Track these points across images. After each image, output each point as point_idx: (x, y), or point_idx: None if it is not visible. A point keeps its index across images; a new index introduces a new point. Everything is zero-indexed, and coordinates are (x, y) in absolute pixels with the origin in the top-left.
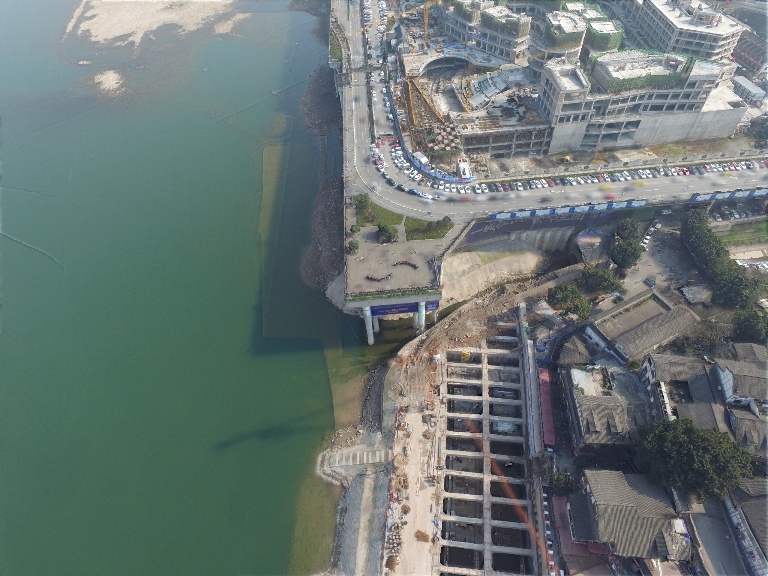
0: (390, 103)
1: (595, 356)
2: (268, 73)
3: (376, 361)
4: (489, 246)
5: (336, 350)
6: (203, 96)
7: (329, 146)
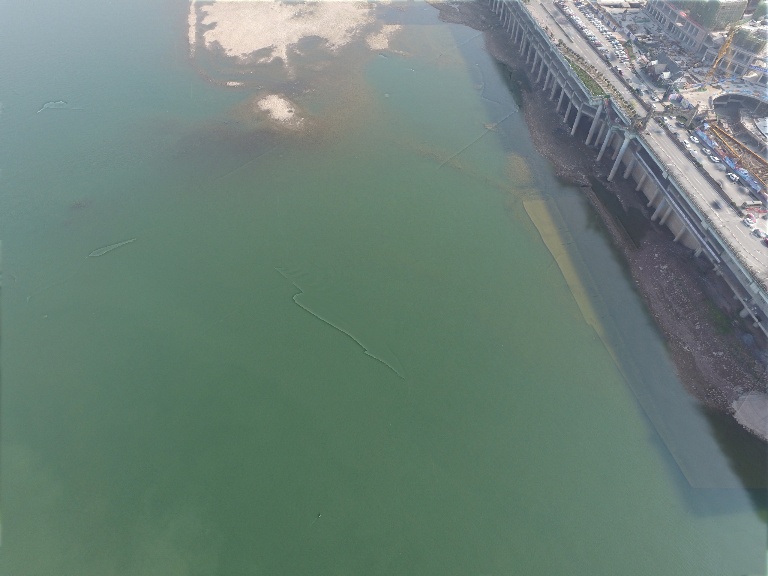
0: None
1: None
2: (465, 101)
3: None
4: None
5: None
6: (405, 130)
7: (602, 201)
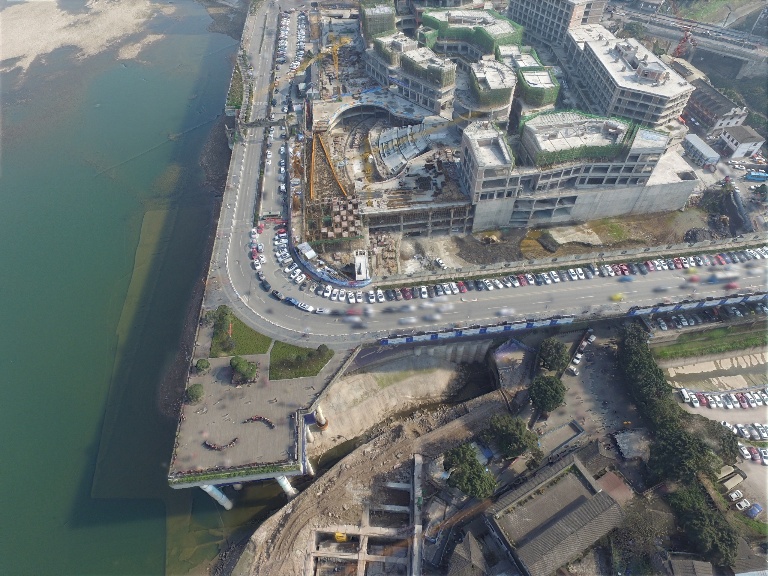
0: (286, 168)
1: (493, 568)
2: (170, 111)
3: (231, 536)
4: (389, 364)
5: (182, 518)
6: (87, 140)
7: None
